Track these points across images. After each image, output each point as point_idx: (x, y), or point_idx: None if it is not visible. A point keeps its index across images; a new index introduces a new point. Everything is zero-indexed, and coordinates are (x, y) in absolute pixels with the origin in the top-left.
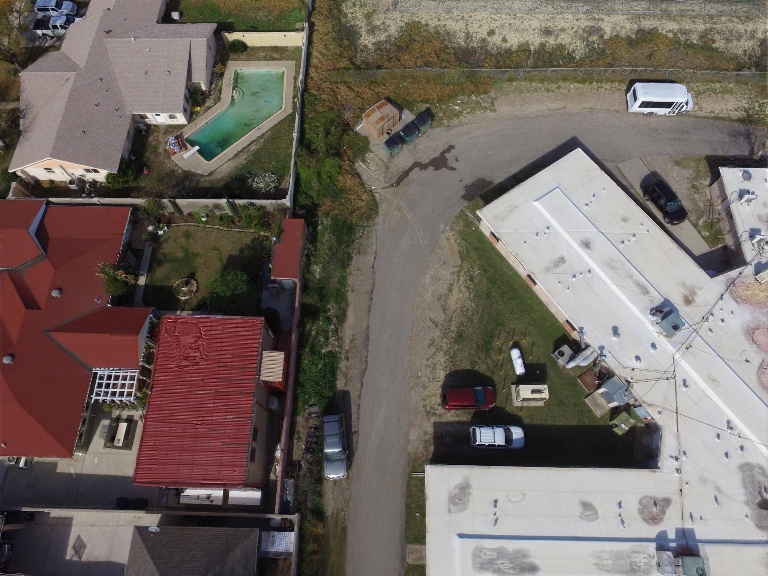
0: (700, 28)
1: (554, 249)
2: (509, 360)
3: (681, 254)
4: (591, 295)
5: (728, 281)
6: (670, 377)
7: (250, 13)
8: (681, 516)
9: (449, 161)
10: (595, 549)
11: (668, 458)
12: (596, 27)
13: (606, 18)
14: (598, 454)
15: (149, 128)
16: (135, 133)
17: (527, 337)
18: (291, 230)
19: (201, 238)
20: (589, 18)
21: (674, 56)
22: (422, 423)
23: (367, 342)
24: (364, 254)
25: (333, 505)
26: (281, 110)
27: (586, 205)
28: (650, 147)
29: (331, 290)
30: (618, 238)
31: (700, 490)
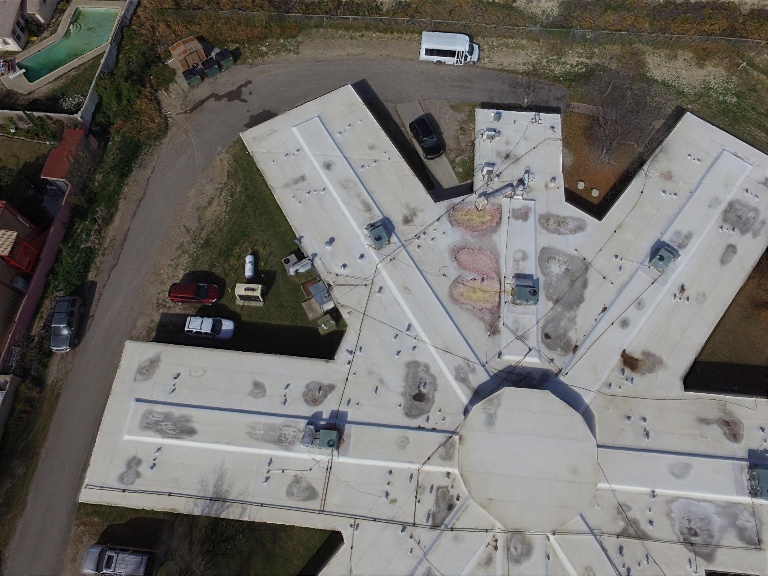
0: None
1: (298, 168)
2: (244, 265)
3: (413, 180)
4: (319, 209)
5: (449, 206)
6: (368, 284)
7: None
8: (340, 400)
9: (243, 94)
10: (252, 420)
11: (344, 351)
12: None
13: None
14: (300, 350)
15: None
16: None
17: (267, 247)
18: None
19: (6, 146)
20: None
21: (473, 12)
22: (151, 312)
23: (124, 242)
24: (144, 168)
25: (55, 375)
26: (106, 43)
27: (339, 133)
28: (431, 92)
29: (104, 196)
30: (359, 163)
31: (364, 380)
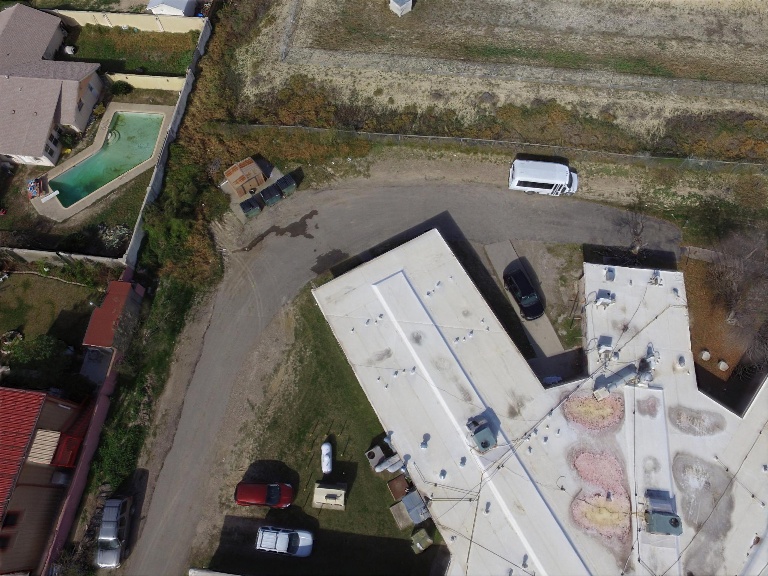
0: (602, 102)
1: (382, 340)
2: (320, 455)
3: (518, 358)
4: (409, 396)
5: (562, 394)
6: (474, 498)
7: (144, 52)
8: None
9: (308, 228)
10: None
11: None
12: (490, 93)
13: (503, 84)
14: (390, 572)
15: (16, 167)
16: (1, 172)
17: (345, 431)
18: (115, 294)
19: (39, 289)
20: (484, 83)
21: (569, 131)
22: (213, 515)
23: (178, 419)
24: (198, 322)
25: None
26: (150, 158)
27: (428, 293)
28: (524, 229)
29: (153, 359)
30: (453, 334)
31: None
